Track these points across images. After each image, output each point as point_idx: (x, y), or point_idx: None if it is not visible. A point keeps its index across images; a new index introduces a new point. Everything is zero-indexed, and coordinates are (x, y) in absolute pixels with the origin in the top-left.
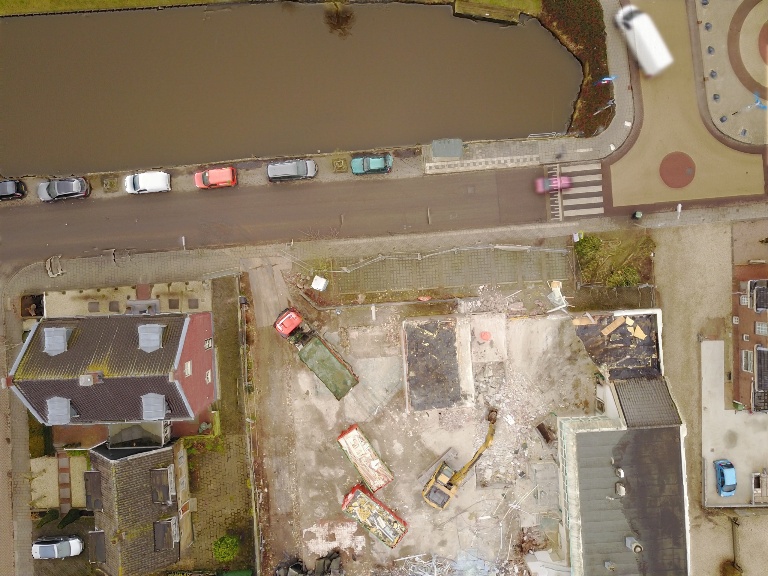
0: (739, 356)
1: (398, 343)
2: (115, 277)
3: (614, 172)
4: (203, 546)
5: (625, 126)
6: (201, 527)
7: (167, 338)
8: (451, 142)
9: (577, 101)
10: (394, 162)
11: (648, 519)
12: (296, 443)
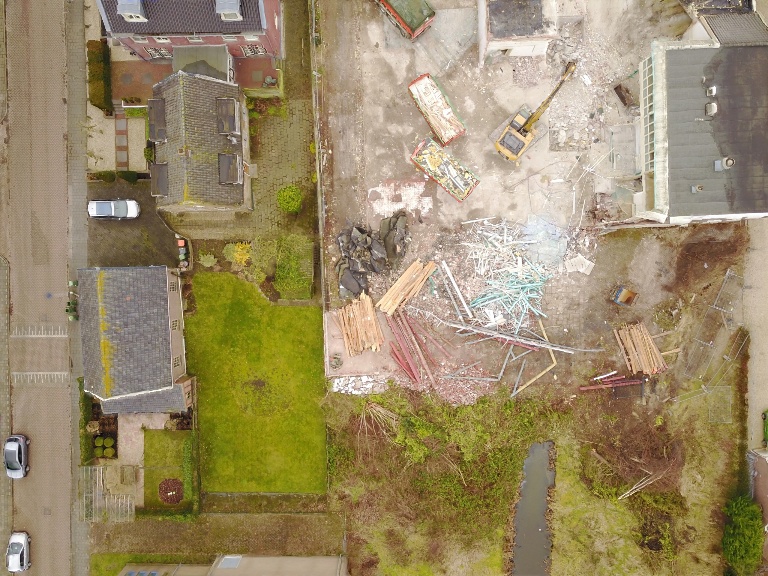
0: None
1: None
2: None
3: None
4: (263, 215)
5: None
6: (261, 195)
7: None
8: None
9: None
10: None
11: (738, 143)
12: (363, 98)
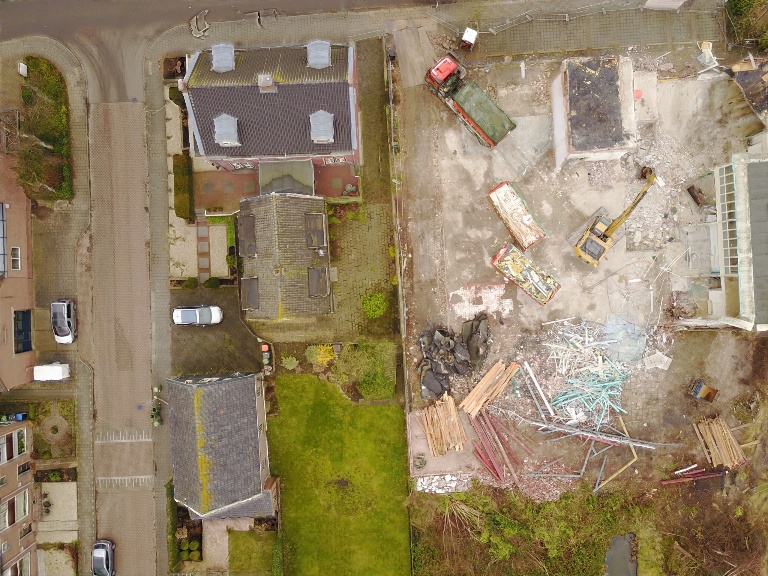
0: None
1: (548, 101)
2: (258, 40)
3: None
4: (343, 317)
5: None
6: (341, 298)
7: (334, 61)
8: None
9: None
10: None
11: None
12: (443, 204)
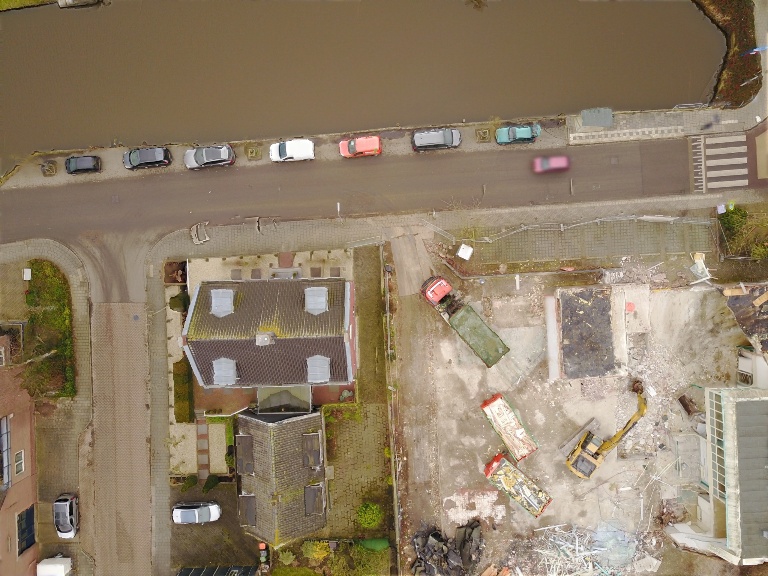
0: None
1: (542, 313)
2: (257, 245)
3: (759, 144)
4: (339, 514)
5: None
6: (337, 495)
7: (331, 301)
8: (601, 111)
9: (722, 73)
10: None
11: None
12: (438, 412)
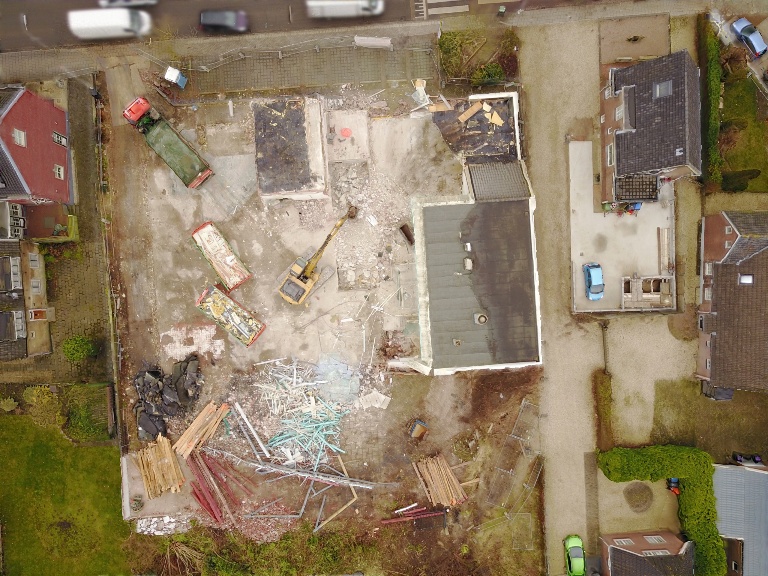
0: (605, 153)
1: None
2: None
3: None
4: (62, 358)
5: None
6: (60, 338)
7: None
8: None
9: None
10: None
11: (498, 296)
12: (153, 244)
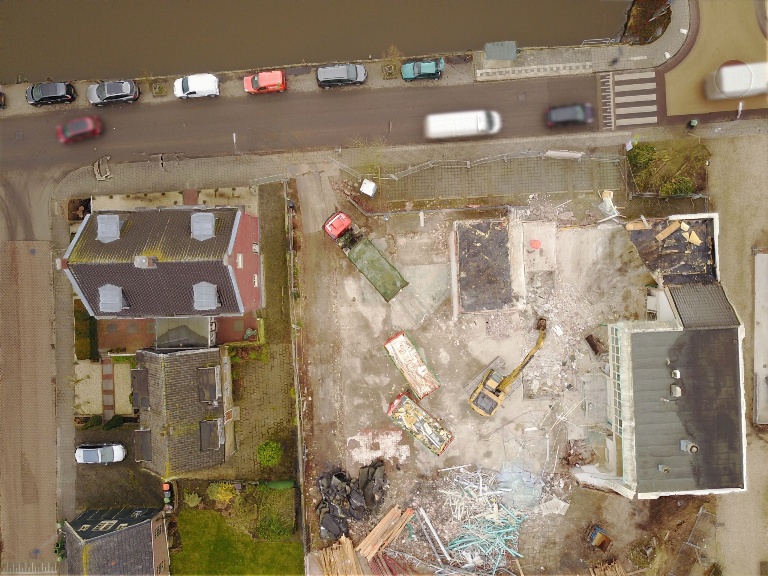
0: None
1: (446, 250)
2: (162, 182)
3: (668, 80)
4: (245, 455)
5: (680, 33)
6: (244, 436)
7: (219, 229)
8: (504, 45)
9: (631, 8)
10: (444, 68)
11: (703, 422)
12: (341, 350)
